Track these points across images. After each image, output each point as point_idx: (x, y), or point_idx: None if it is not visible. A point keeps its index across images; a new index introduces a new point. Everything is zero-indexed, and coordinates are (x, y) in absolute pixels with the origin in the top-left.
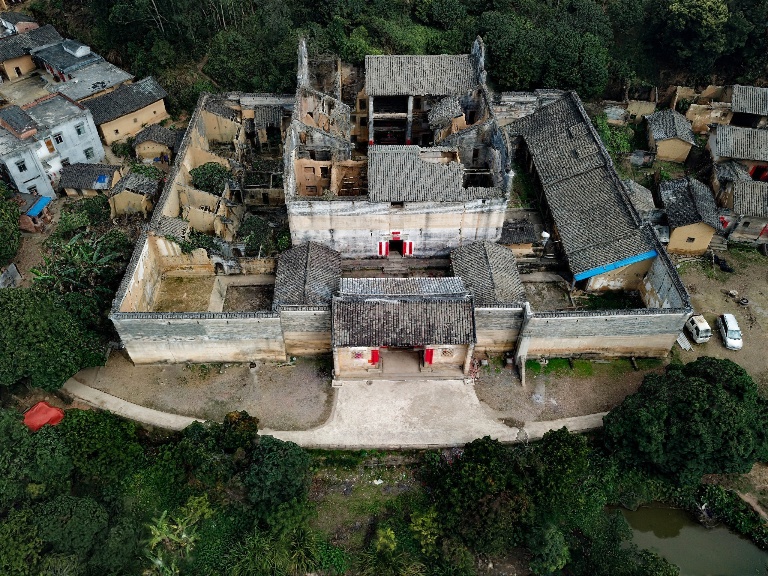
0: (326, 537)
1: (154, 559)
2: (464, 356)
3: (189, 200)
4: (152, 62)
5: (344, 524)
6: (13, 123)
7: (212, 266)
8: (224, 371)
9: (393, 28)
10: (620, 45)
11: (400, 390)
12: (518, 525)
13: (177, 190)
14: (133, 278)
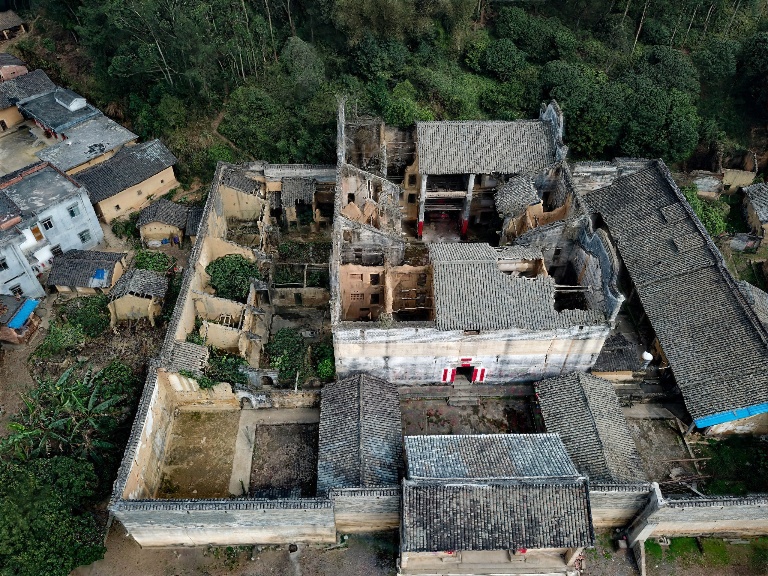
0: None
1: None
2: None
3: (207, 308)
4: (159, 120)
5: None
6: None
7: (237, 400)
8: (257, 557)
9: (441, 79)
10: (706, 99)
11: None
12: None
13: (192, 298)
14: (140, 440)
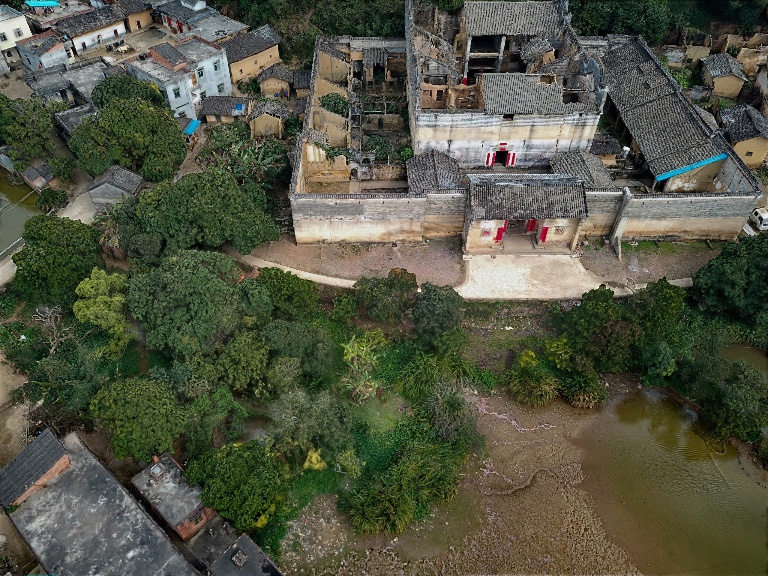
0: (474, 364)
1: (353, 366)
2: (572, 234)
3: (321, 121)
4: (266, 13)
5: (487, 356)
6: (167, 57)
7: (348, 172)
8: (372, 249)
9: None
10: None
11: (520, 262)
12: (631, 350)
13: (313, 111)
14: None
